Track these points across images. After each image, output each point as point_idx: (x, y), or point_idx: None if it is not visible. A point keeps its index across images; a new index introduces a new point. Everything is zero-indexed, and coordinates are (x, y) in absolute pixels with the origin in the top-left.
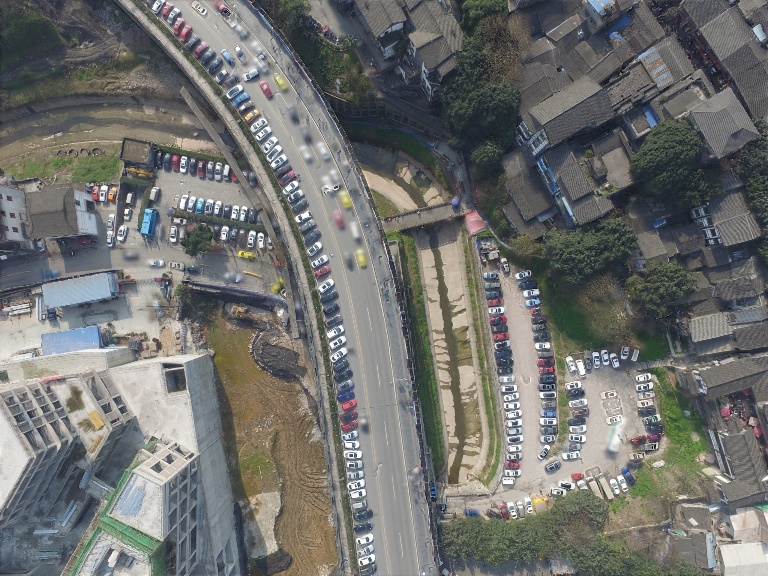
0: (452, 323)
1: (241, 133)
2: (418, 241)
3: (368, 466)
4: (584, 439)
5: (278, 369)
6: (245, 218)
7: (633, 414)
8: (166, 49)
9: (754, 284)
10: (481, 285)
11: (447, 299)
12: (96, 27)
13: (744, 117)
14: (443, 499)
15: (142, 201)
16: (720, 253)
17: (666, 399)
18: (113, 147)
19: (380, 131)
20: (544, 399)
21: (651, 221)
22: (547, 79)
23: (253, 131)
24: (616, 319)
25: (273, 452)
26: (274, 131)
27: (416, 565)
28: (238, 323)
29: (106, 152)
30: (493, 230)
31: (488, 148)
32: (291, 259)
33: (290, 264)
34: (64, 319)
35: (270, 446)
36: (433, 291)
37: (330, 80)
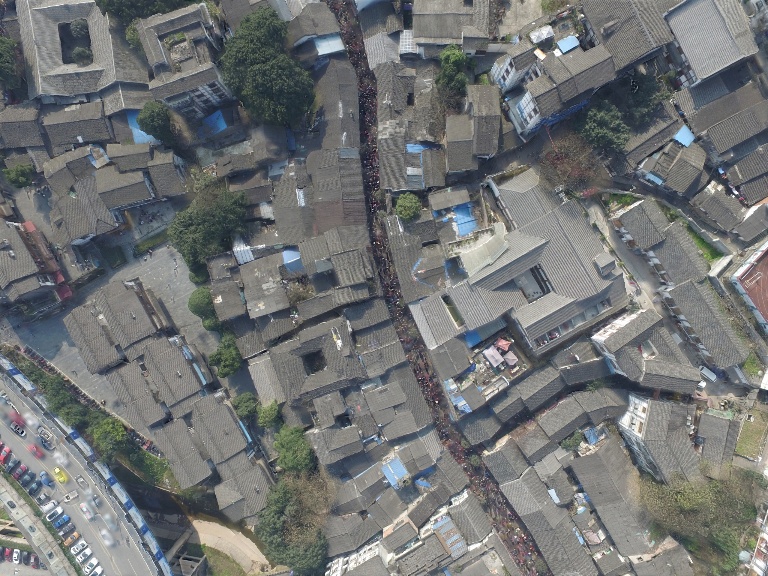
0: None
1: (62, 553)
2: None
3: None
4: None
5: None
6: None
7: None
8: None
9: None
10: None
11: None
12: None
13: None
14: None
15: None
16: None
17: None
18: None
19: None
20: None
21: None
22: (349, 536)
23: (73, 553)
24: None
25: None
26: (95, 552)
27: None
28: None
29: None
30: None
31: None
32: None
33: None
34: None
35: None
36: None
37: (159, 479)
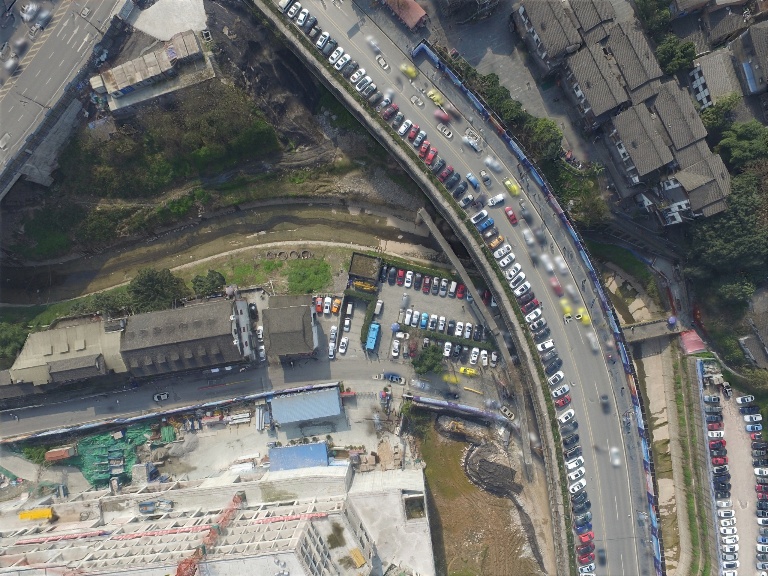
0: (653, 435)
1: (484, 258)
2: None
3: None
4: None
5: (494, 486)
6: (470, 335)
7: None
8: (414, 173)
9: None
10: (701, 408)
11: (649, 411)
12: (314, 132)
13: None
14: None
15: (365, 314)
16: None
17: None
18: (322, 250)
19: (595, 244)
20: (762, 525)
21: None
22: None
23: (497, 257)
24: None
25: (482, 567)
26: (517, 257)
27: None
28: (451, 436)
29: (315, 255)
30: (718, 354)
31: (746, 288)
32: (537, 390)
33: (528, 391)
34: (282, 429)
35: (480, 561)
36: None
37: (563, 201)
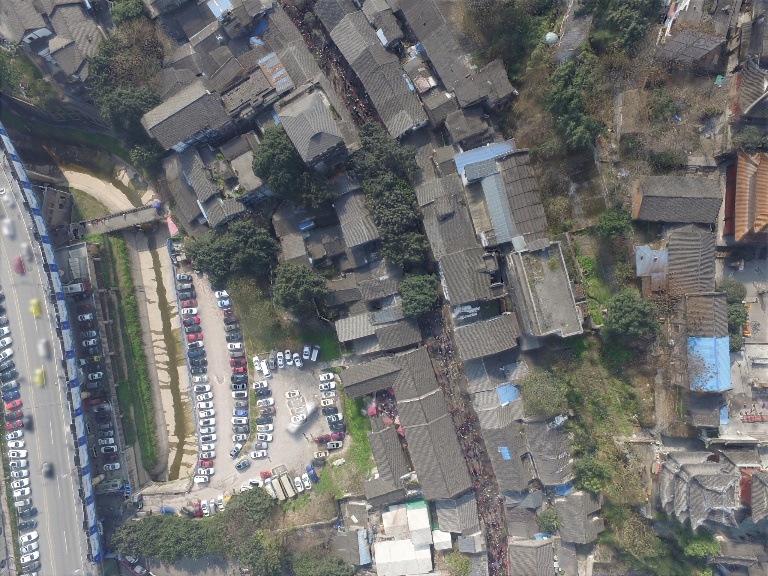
0: (171, 324)
1: None
2: (135, 243)
3: (33, 465)
4: (270, 438)
5: None
6: None
7: (318, 413)
8: None
9: (384, 285)
10: (175, 286)
11: (166, 300)
12: None
13: (326, 121)
14: (134, 497)
15: None
16: (358, 254)
17: (347, 398)
18: None
19: (87, 135)
20: (236, 398)
21: (296, 223)
22: (179, 84)
23: None
24: (283, 320)
25: None
26: None
27: (80, 562)
28: None
29: None
30: None
31: (135, 152)
32: None
33: None
34: None
35: None
36: (152, 292)
37: (14, 85)
